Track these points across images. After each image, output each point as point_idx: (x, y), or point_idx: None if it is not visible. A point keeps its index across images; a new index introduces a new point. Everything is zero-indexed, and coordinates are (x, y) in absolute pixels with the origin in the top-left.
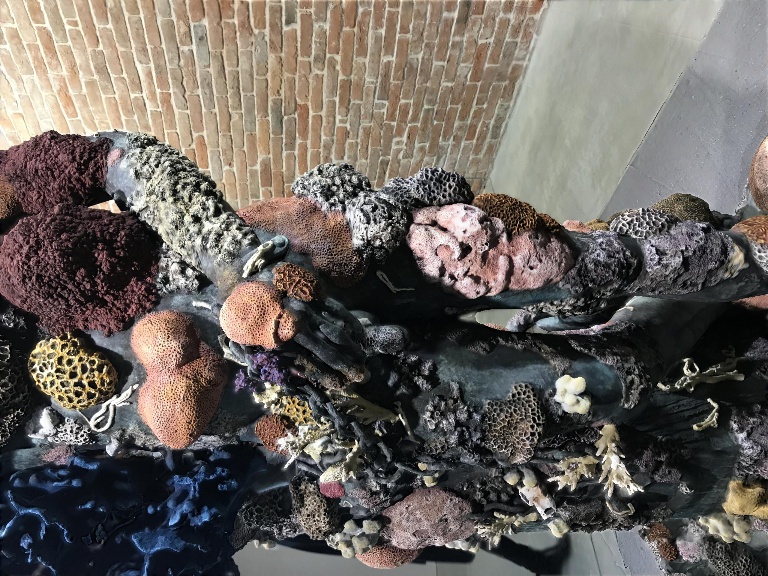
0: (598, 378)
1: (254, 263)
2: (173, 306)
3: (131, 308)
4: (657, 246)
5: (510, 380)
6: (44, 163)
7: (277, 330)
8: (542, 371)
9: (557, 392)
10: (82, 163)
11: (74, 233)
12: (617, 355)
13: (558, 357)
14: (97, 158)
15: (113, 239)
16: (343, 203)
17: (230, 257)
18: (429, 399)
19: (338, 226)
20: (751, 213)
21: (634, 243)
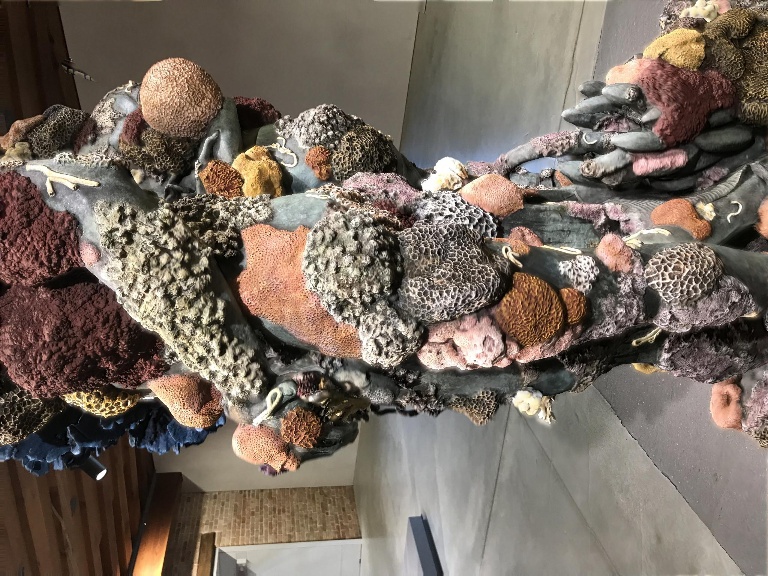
0: (556, 385)
1: (263, 420)
2: (183, 370)
3: (144, 377)
4: (675, 314)
5: (481, 385)
6: (7, 270)
7: (283, 466)
8: (511, 382)
9: (516, 398)
10: (52, 266)
11: (74, 358)
12: (585, 362)
13: (531, 370)
14: (68, 256)
15: (114, 348)
16: (358, 316)
17: (240, 405)
18: (408, 392)
19: (349, 337)
20: None
21: (657, 300)
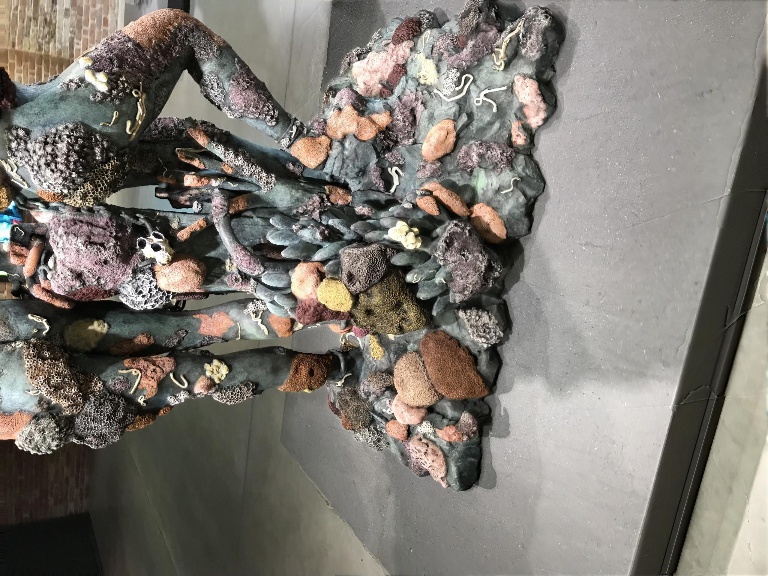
0: None
1: None
2: None
3: None
4: None
5: None
6: None
7: None
8: None
9: None
10: None
11: None
12: None
13: None
14: None
15: None
16: None
17: None
18: None
19: None
20: (447, 320)
21: None
